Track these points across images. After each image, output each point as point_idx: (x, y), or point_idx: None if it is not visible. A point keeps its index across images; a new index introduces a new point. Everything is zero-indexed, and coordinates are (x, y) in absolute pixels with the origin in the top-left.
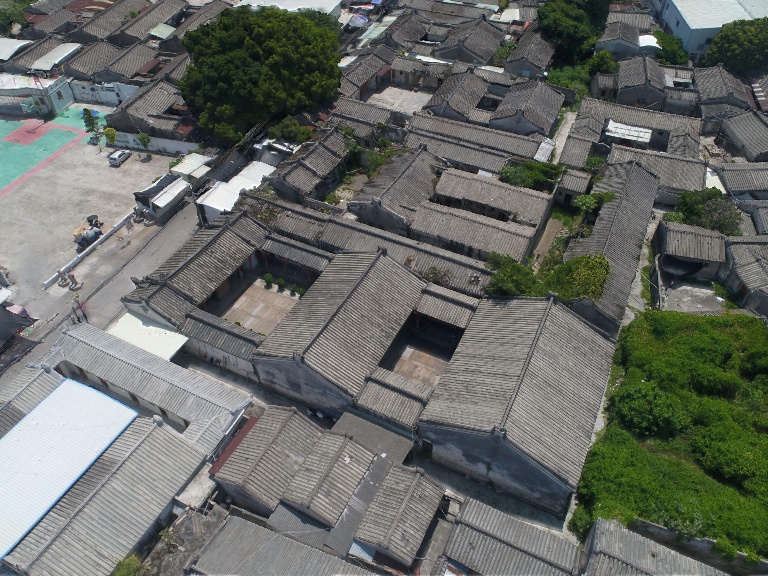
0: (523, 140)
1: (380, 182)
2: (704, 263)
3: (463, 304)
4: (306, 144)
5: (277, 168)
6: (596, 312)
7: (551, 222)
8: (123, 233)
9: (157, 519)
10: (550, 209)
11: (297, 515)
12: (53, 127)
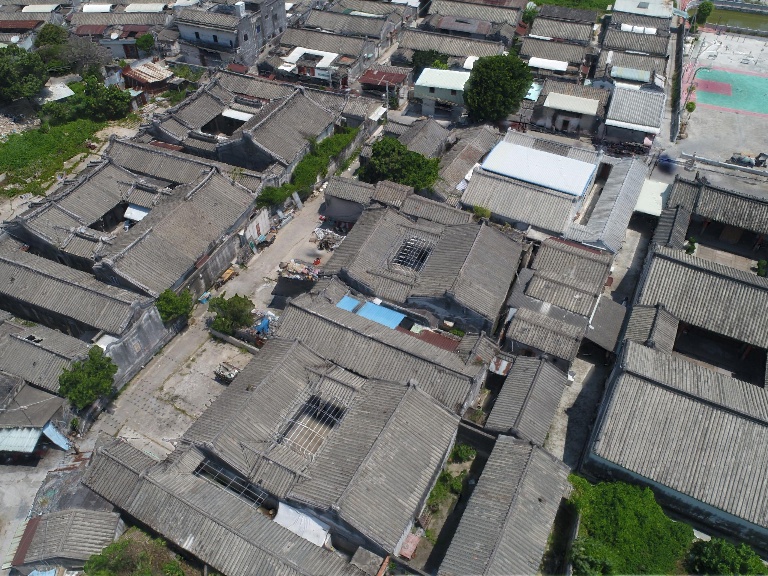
0: None
1: None
2: None
3: None
4: None
5: None
6: None
7: None
8: (763, 179)
9: (515, 222)
10: None
11: None
12: None
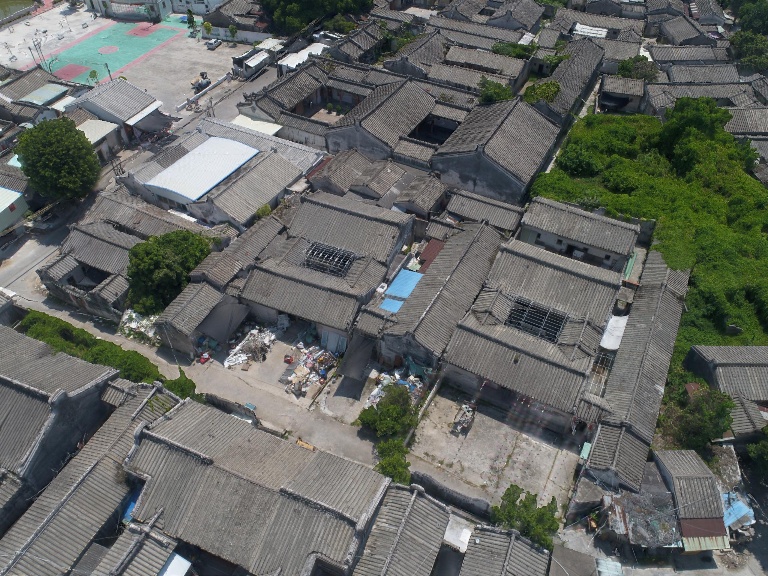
0: (510, 31)
1: (406, 51)
2: (630, 99)
3: (462, 108)
4: (352, 31)
5: (332, 45)
6: (548, 110)
7: (528, 83)
8: (224, 85)
9: (277, 197)
10: (528, 75)
11: (360, 195)
12: (160, 27)
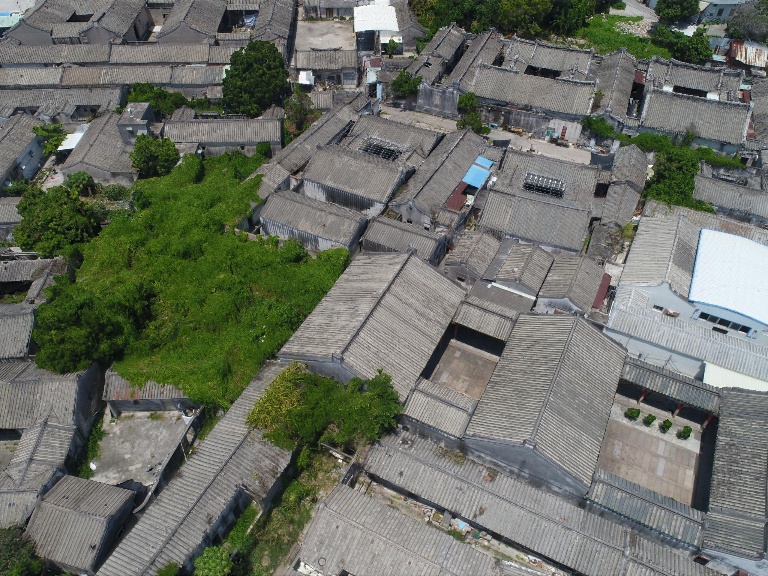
0: None
1: None
2: None
3: None
4: None
5: None
6: None
7: None
8: None
9: None
10: None
11: None
12: None
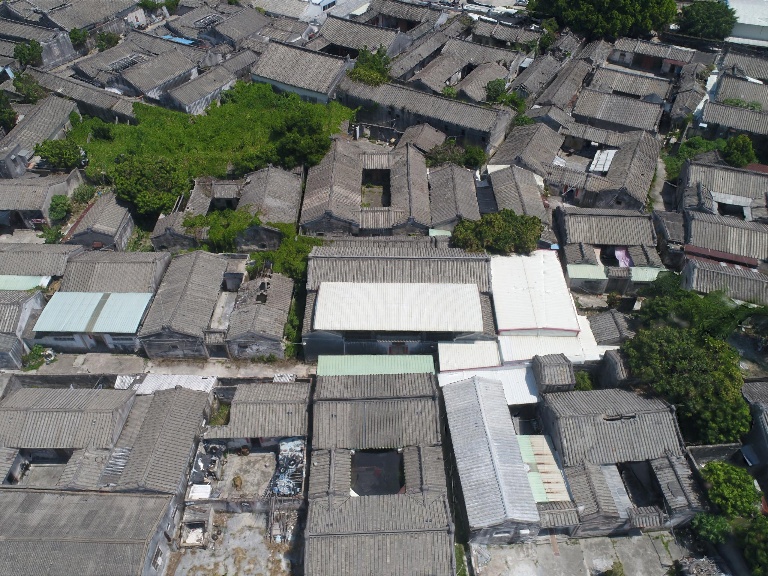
0: None
1: None
2: None
3: None
4: None
5: None
6: None
7: None
8: None
9: None
10: None
11: None
12: None
